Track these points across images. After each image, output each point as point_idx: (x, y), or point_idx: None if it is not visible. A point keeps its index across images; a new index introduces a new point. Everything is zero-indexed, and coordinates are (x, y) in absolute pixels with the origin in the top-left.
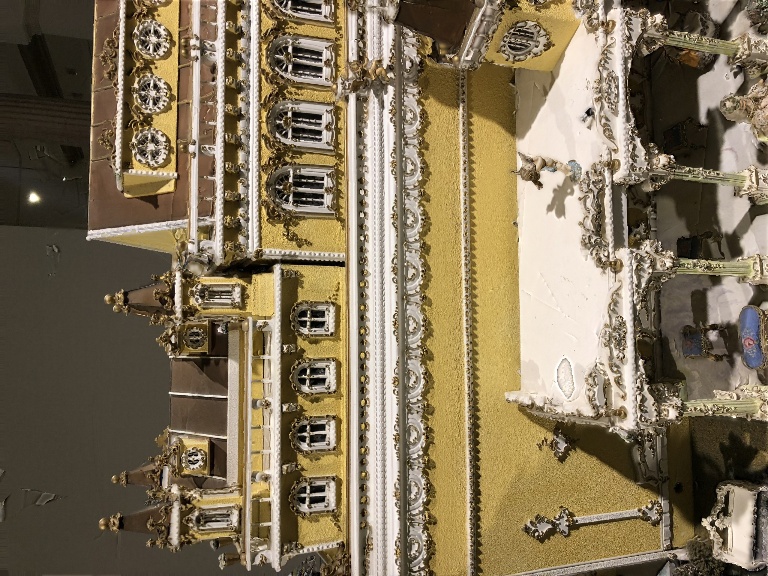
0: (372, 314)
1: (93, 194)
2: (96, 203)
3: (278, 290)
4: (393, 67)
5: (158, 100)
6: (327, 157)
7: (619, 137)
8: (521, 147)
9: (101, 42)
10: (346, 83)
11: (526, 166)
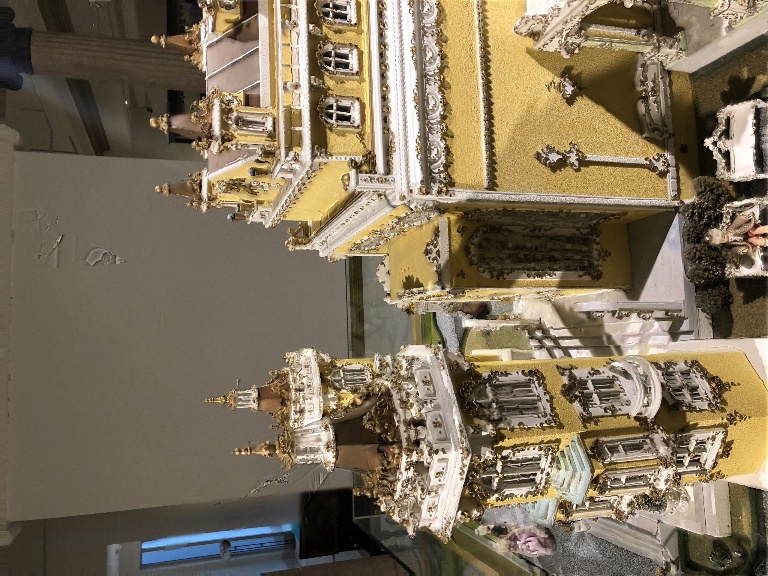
0: None
1: None
2: None
3: None
4: None
5: None
6: None
7: None
8: None
9: None
10: None
11: None
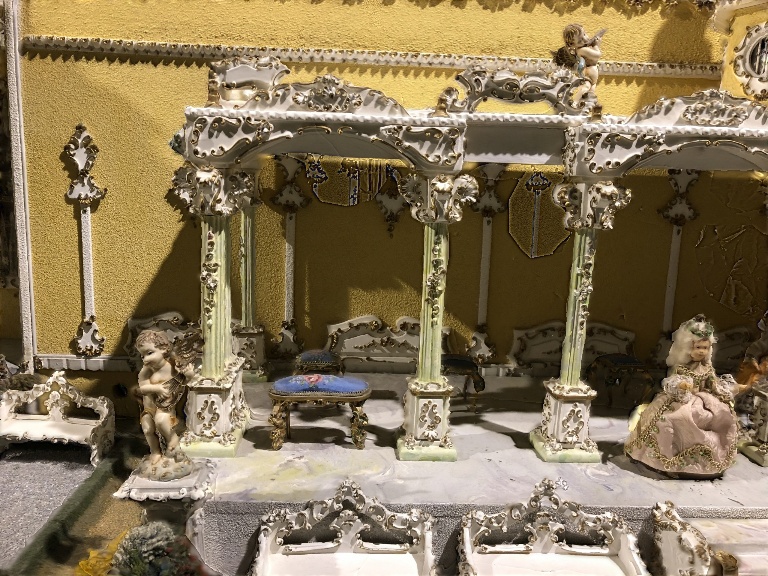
0: None
1: None
2: None
3: None
4: None
5: None
6: None
7: None
8: None
9: None
10: None
11: None
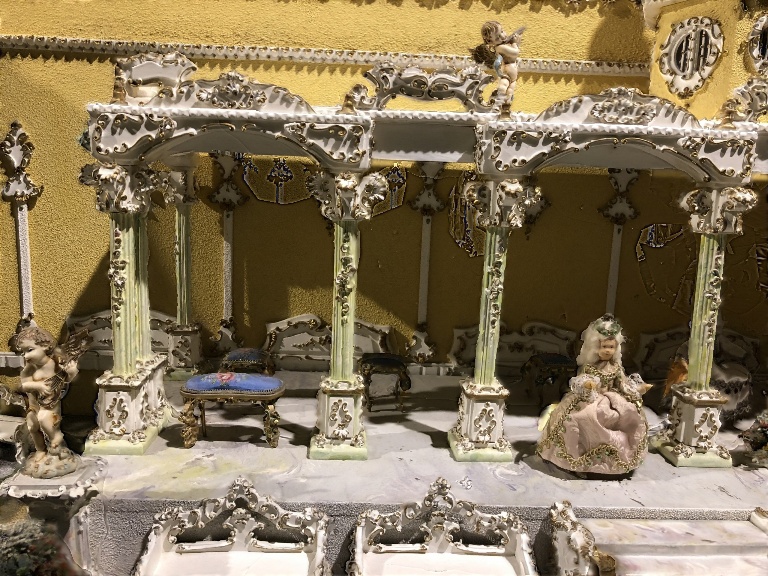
0: None
1: None
2: None
3: None
4: None
5: None
6: None
7: None
8: None
9: None
10: None
11: None
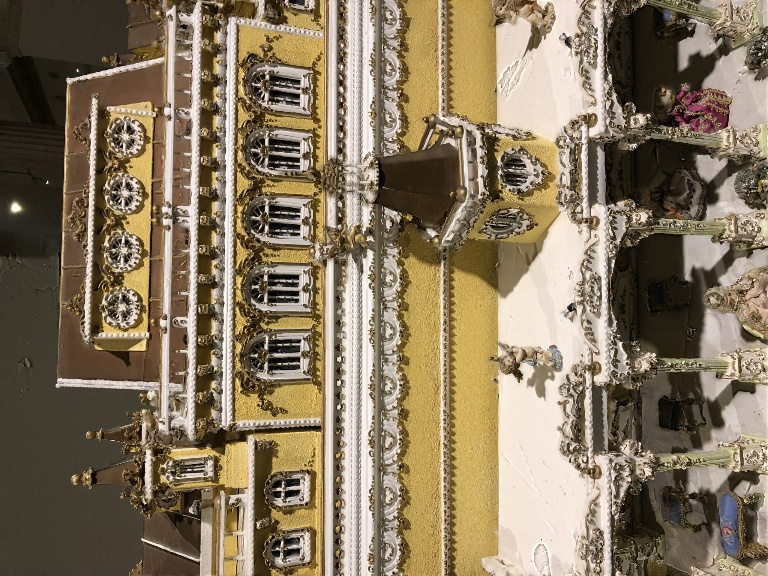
0: (348, 488)
1: (63, 339)
2: (66, 350)
3: (252, 466)
4: (373, 230)
5: (130, 256)
6: (304, 319)
7: (601, 341)
8: (503, 306)
9: (72, 179)
10: (324, 248)
11: (506, 359)
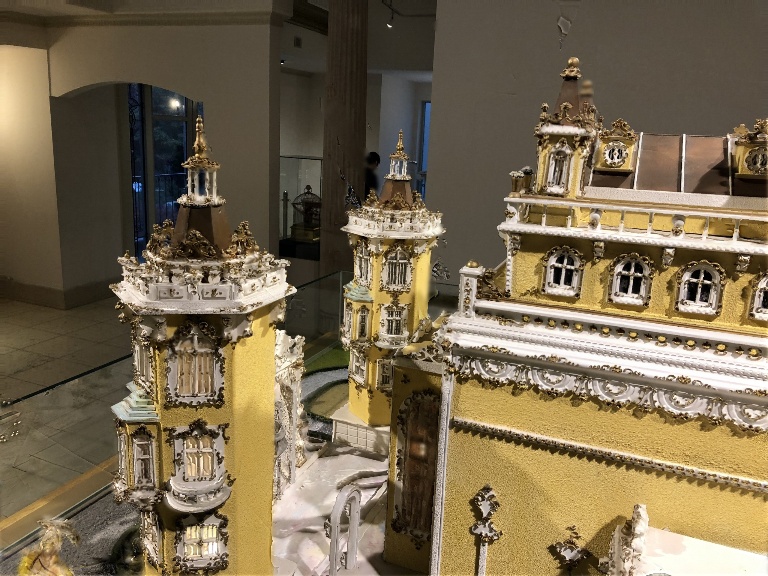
0: None
1: None
2: None
3: None
4: None
5: None
6: None
7: None
8: None
9: None
10: None
11: None
